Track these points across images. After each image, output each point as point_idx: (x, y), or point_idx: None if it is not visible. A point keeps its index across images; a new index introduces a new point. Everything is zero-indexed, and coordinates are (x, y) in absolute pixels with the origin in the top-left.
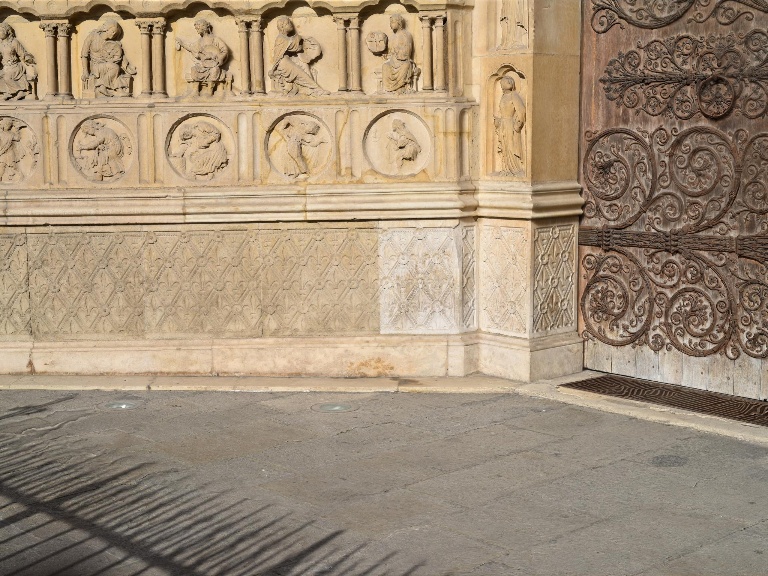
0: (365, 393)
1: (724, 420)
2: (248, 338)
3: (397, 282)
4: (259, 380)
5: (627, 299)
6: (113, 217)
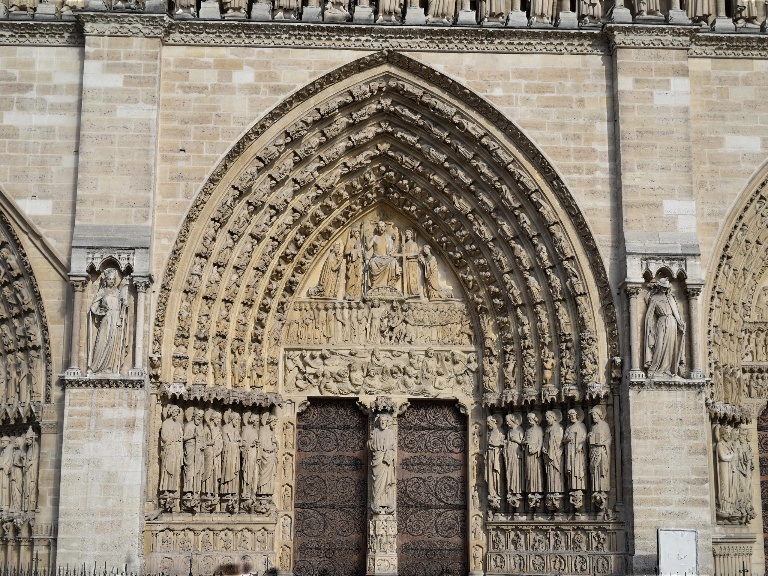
0: None
1: None
2: None
3: None
4: None
5: None
6: None
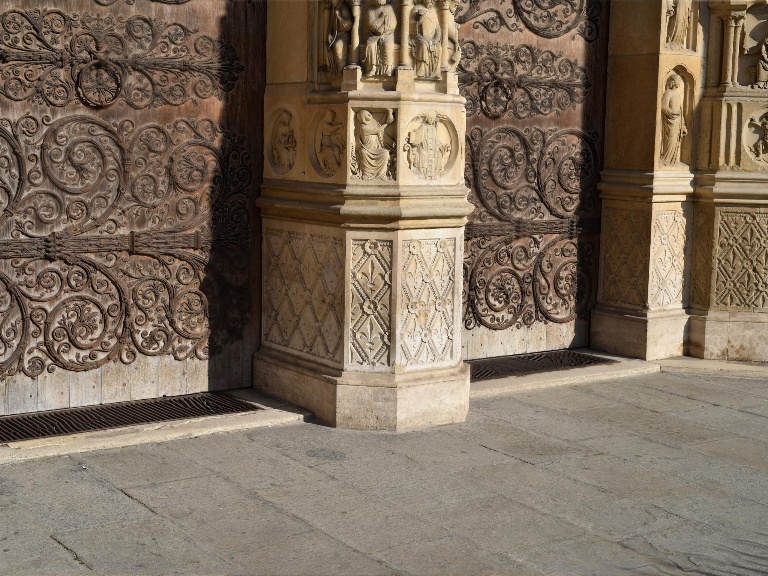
0: None
1: (221, 417)
2: None
3: None
4: None
5: None
6: None
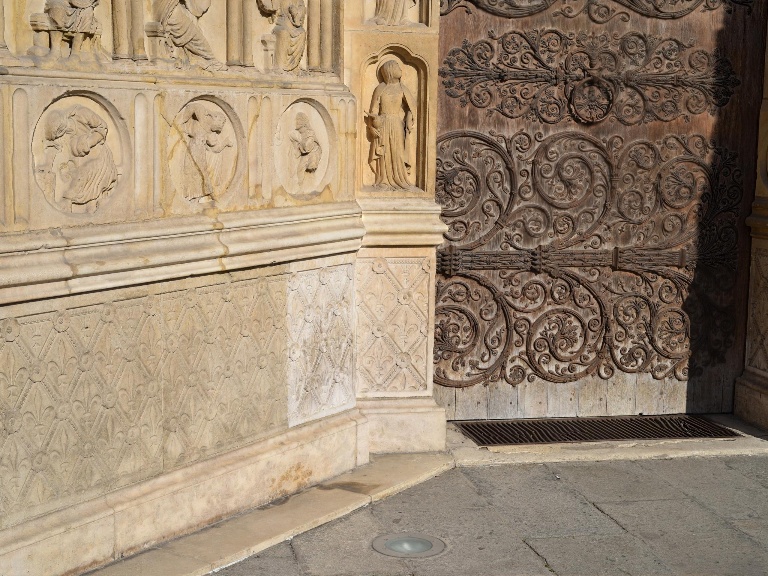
0: (350, 516)
1: (698, 441)
2: (150, 480)
3: (303, 349)
4: (201, 543)
5: (479, 331)
6: None
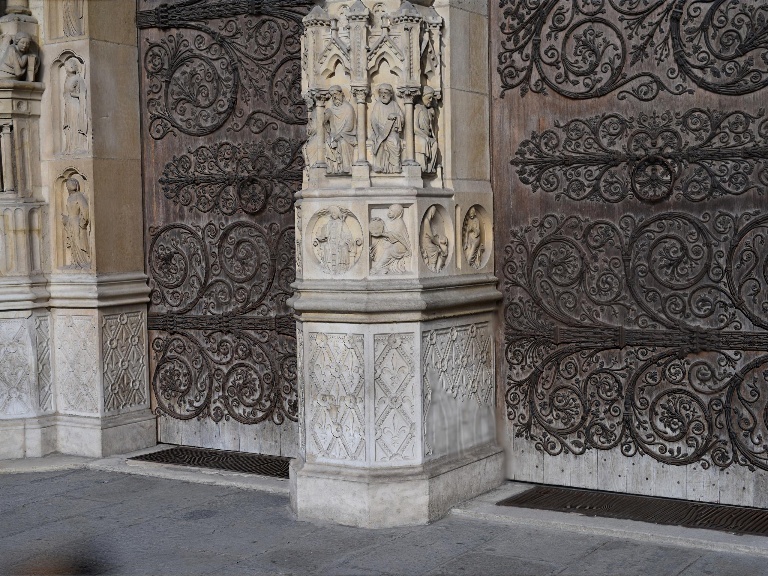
0: None
1: (262, 477)
2: None
3: None
4: None
5: (191, 377)
6: None
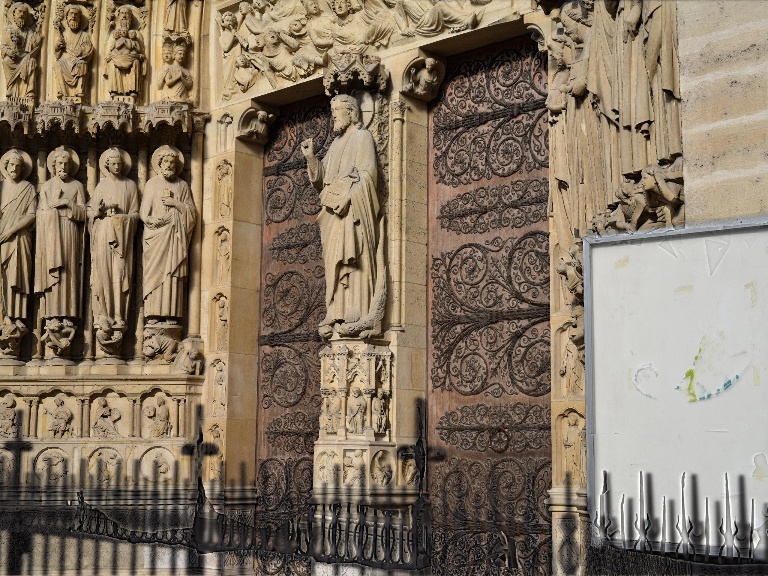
0: None
1: None
2: (71, 570)
3: None
4: None
5: None
6: (2, 502)
